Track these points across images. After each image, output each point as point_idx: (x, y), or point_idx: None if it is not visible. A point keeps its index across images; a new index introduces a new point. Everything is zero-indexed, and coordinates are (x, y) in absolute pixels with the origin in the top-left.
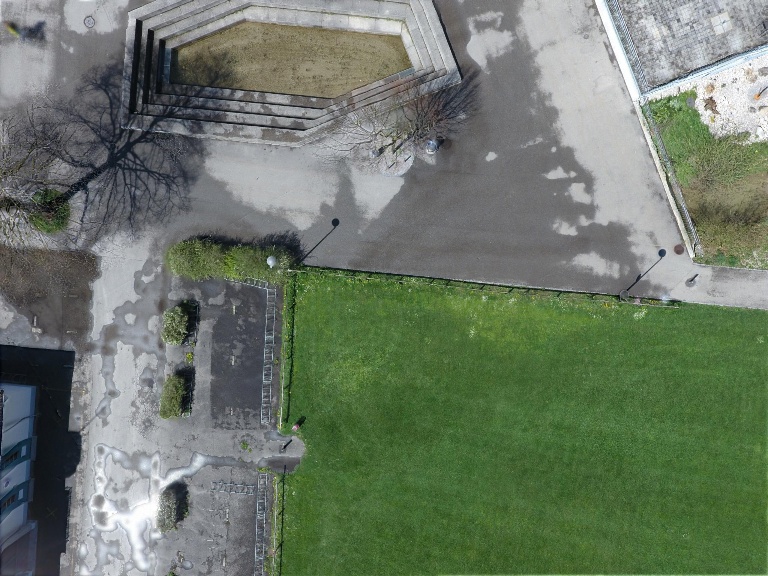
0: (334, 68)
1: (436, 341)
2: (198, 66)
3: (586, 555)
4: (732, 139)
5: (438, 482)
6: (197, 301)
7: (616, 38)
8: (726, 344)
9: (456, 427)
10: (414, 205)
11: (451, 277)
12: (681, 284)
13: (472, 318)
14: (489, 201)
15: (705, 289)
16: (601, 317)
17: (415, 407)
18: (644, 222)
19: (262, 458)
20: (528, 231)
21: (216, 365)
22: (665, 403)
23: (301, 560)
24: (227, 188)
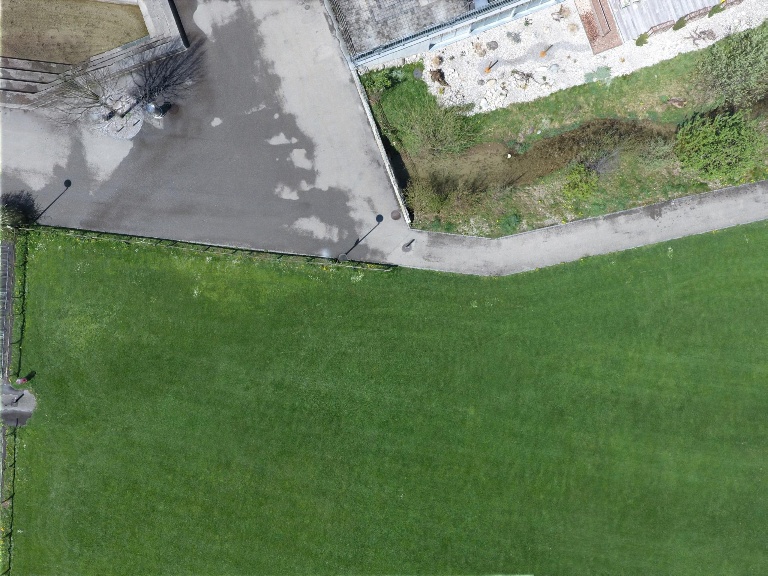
0: (77, 36)
1: (161, 300)
2: None
3: (306, 513)
4: (456, 110)
5: (163, 438)
6: None
7: (330, 8)
8: (441, 308)
9: (180, 384)
10: (143, 168)
11: (178, 238)
12: (397, 249)
13: (196, 278)
14: (214, 165)
15: (421, 254)
16: (320, 280)
17: (141, 364)
18: (362, 188)
19: None
20: (251, 195)
21: None
22: (382, 365)
23: (32, 512)
24: None
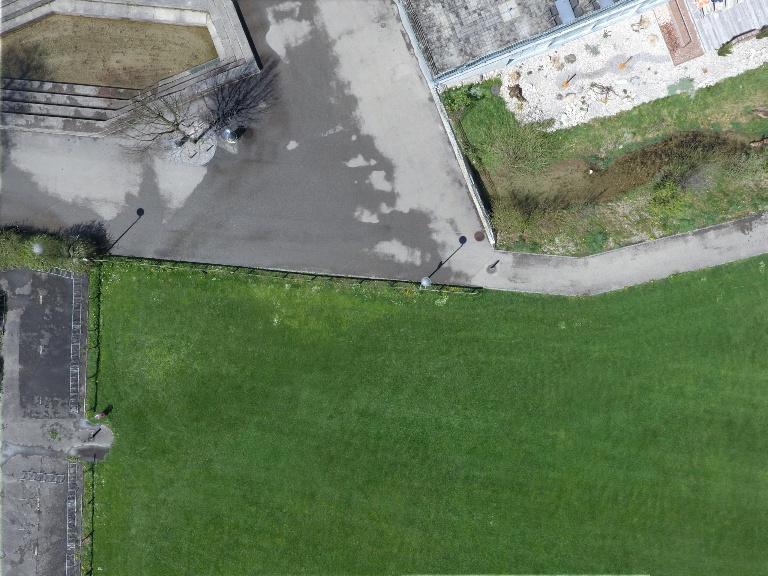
0: (144, 59)
1: (240, 329)
2: (10, 59)
3: (394, 543)
4: (536, 126)
5: (245, 470)
6: (4, 291)
7: (409, 26)
8: (528, 330)
9: (262, 415)
10: (217, 194)
11: (255, 265)
12: (482, 271)
13: (275, 306)
14: (291, 189)
15: (506, 275)
16: (403, 304)
17: (221, 395)
18: (444, 209)
19: (71, 447)
20: (330, 219)
21: (24, 355)
22: (468, 390)
23: (112, 549)
24: (33, 179)
